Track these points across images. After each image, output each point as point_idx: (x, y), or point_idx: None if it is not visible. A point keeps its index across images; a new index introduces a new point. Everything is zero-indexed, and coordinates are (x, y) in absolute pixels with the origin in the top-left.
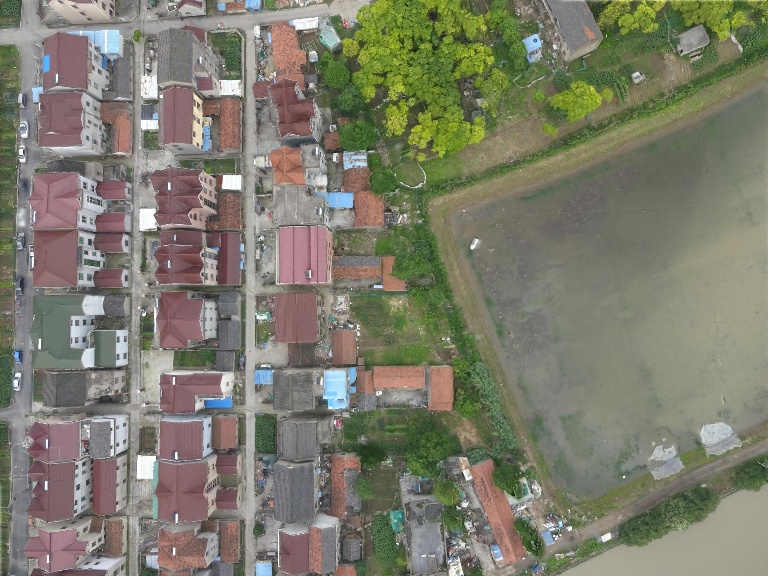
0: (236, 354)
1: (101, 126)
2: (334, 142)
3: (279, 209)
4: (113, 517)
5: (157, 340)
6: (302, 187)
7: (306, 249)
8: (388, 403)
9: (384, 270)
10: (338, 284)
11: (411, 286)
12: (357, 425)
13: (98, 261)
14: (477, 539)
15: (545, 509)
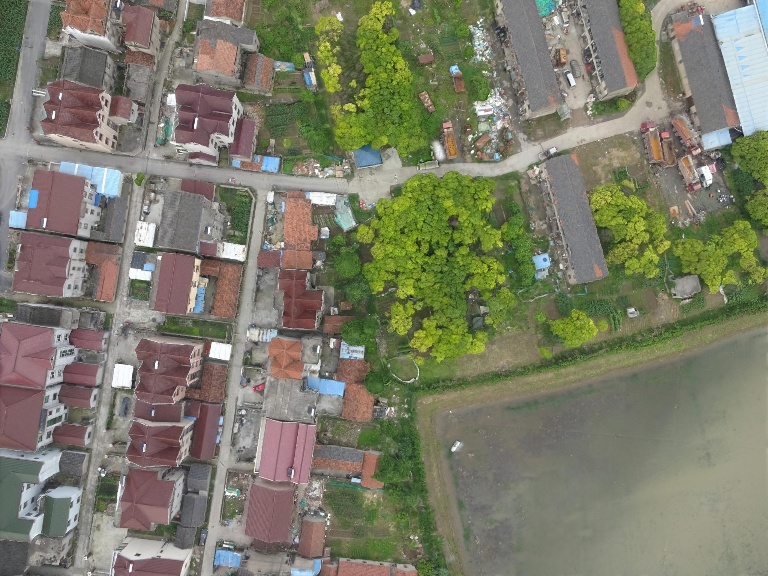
0: (198, 528)
1: (84, 267)
2: (334, 327)
3: (270, 401)
4: None
5: (117, 518)
6: (297, 382)
7: (291, 445)
8: None
9: (365, 466)
10: (315, 469)
11: (388, 483)
12: None
13: (60, 415)
14: None
15: None
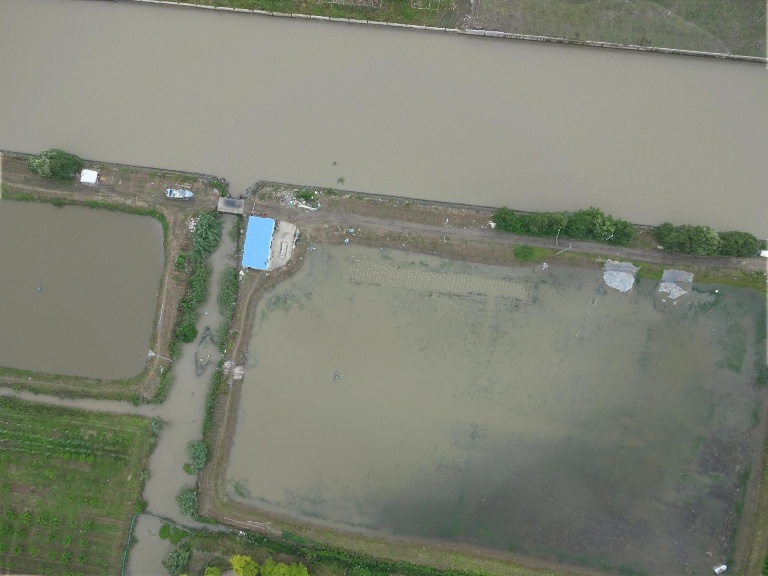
0: None
1: None
2: None
3: None
4: None
5: None
6: None
7: None
8: None
9: None
10: None
11: None
12: None
13: None
14: None
15: None
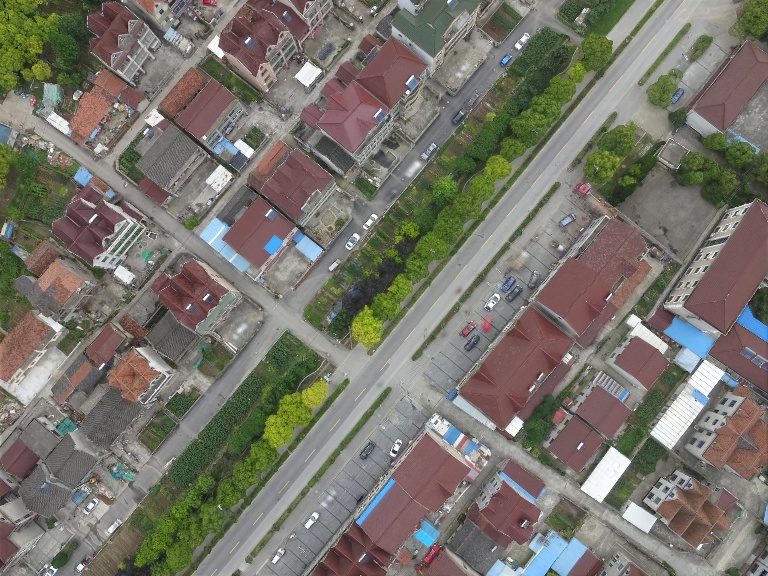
0: None
1: None
2: None
3: None
4: None
5: None
6: None
7: None
8: None
9: None
10: None
11: None
12: None
13: None
14: None
15: None
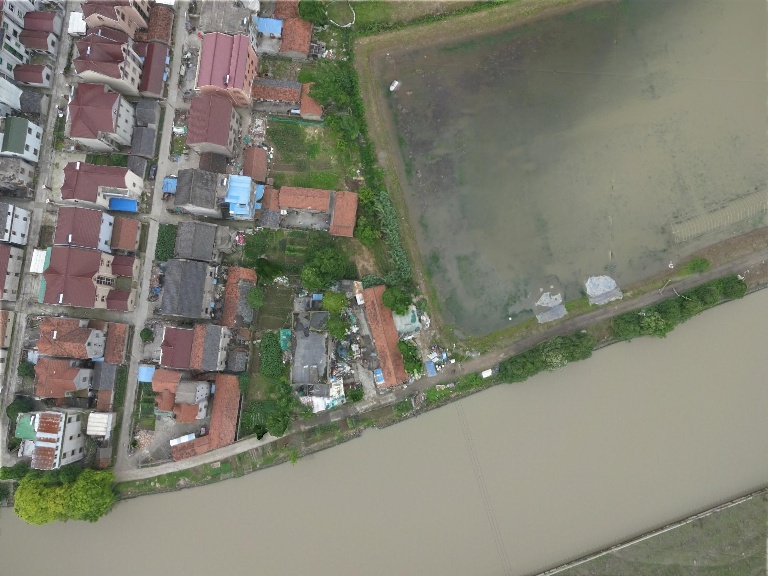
0: (148, 164)
1: None
2: None
3: (206, 16)
4: (0, 309)
5: (68, 128)
6: None
7: (227, 57)
8: (292, 225)
9: (303, 95)
10: (258, 107)
11: None
12: (259, 243)
13: (21, 55)
14: (362, 364)
15: (431, 340)
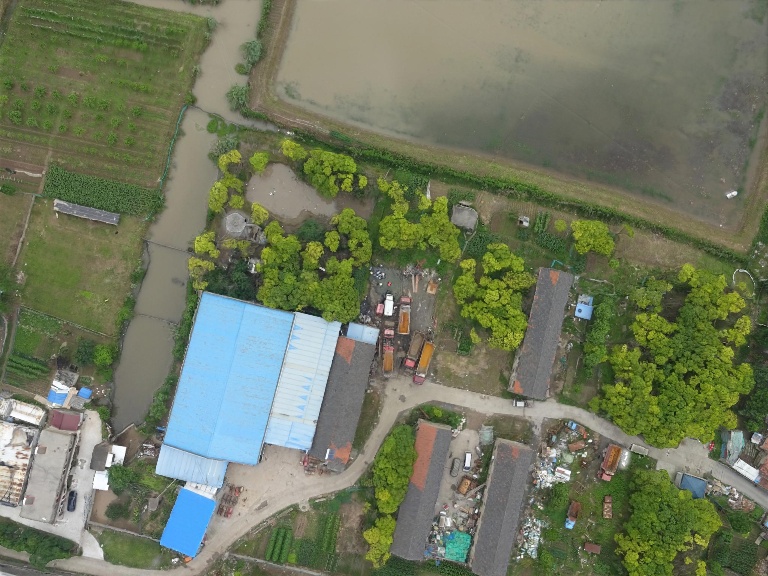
0: None
1: None
2: None
3: None
4: None
5: None
6: None
7: None
8: None
9: None
10: None
11: None
12: None
13: None
14: None
15: None
